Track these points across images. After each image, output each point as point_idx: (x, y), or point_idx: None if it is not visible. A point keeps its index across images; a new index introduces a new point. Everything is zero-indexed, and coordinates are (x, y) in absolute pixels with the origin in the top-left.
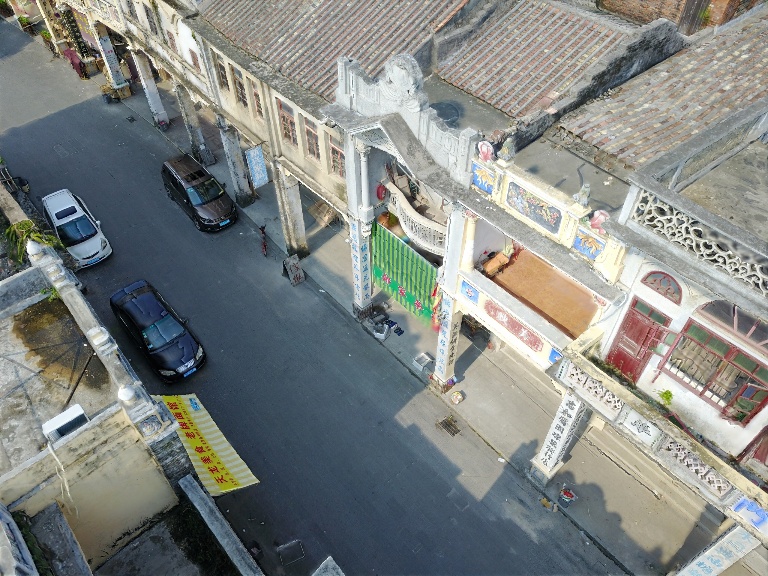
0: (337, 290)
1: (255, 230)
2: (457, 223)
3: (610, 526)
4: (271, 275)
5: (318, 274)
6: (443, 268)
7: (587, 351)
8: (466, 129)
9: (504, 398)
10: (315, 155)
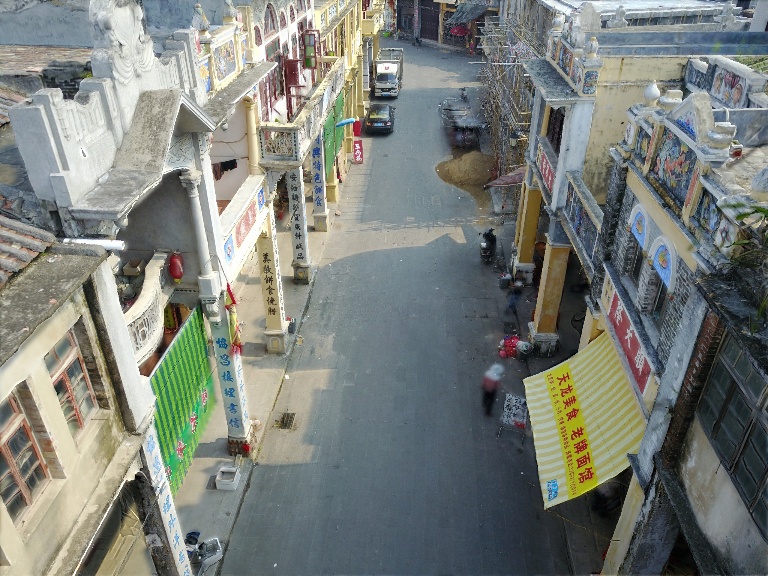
0: None
1: None
2: (208, 173)
3: (287, 309)
4: None
5: None
6: (211, 272)
7: (265, 153)
8: (180, 31)
9: (220, 400)
10: (26, 499)
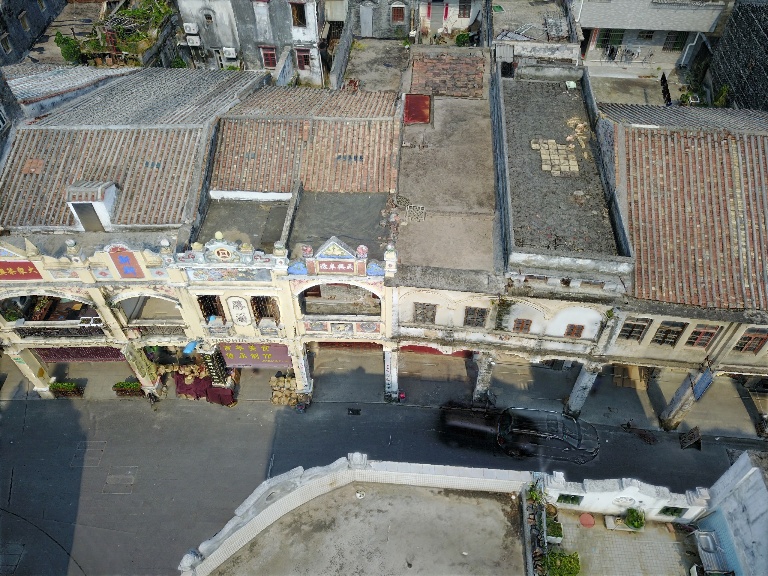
0: (727, 430)
1: (610, 430)
2: None
3: None
4: (676, 455)
5: (700, 428)
6: None
7: None
8: None
9: None
10: None
